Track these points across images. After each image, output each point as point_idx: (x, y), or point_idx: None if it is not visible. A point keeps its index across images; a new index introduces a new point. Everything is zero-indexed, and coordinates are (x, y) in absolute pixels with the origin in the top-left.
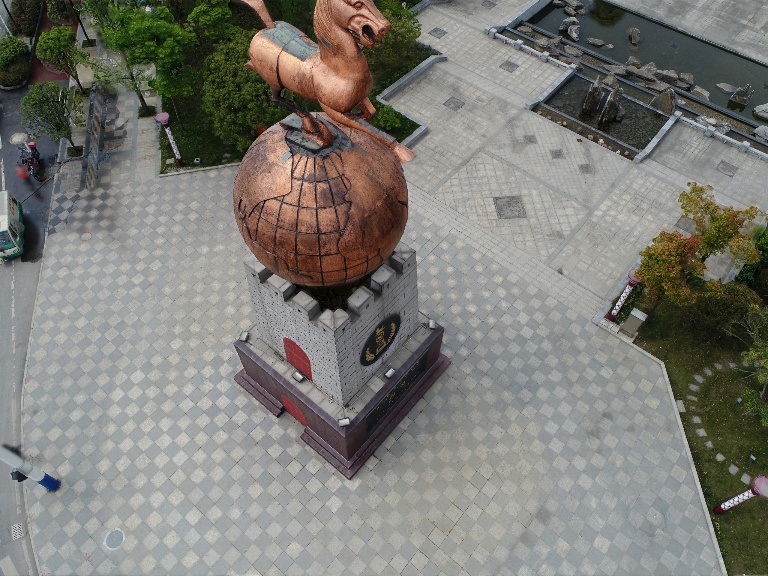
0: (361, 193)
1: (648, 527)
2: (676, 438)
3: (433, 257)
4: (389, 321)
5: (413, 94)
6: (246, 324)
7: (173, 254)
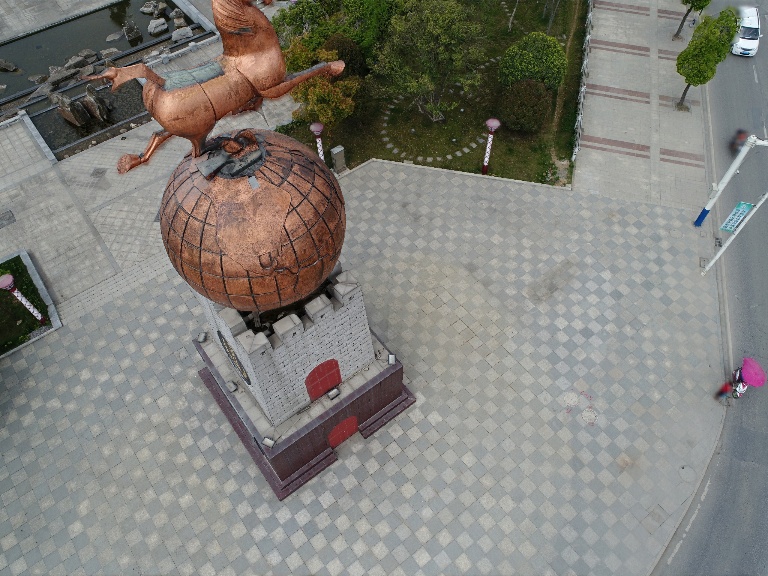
0: (307, 151)
1: (490, 210)
2: (431, 173)
3: None
4: None
5: None
6: (212, 482)
7: (62, 573)
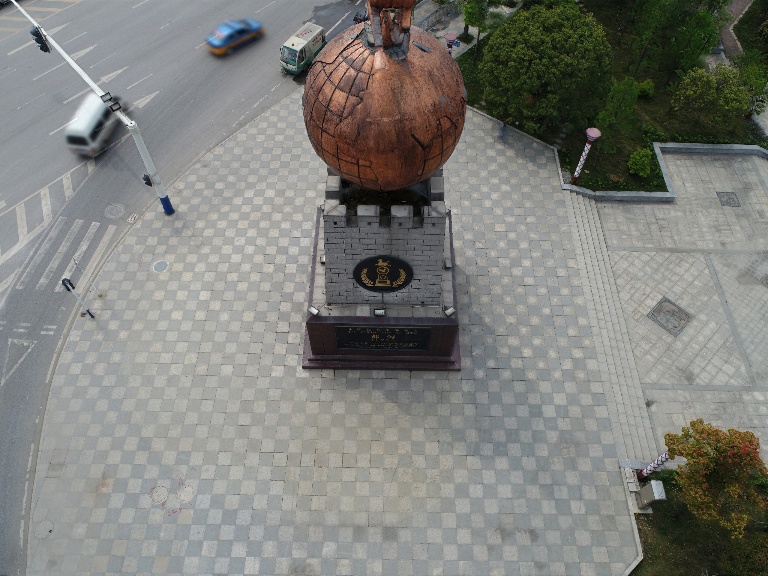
0: (375, 99)
1: None
2: None
3: (544, 291)
4: (398, 264)
5: (697, 165)
6: None
7: None
